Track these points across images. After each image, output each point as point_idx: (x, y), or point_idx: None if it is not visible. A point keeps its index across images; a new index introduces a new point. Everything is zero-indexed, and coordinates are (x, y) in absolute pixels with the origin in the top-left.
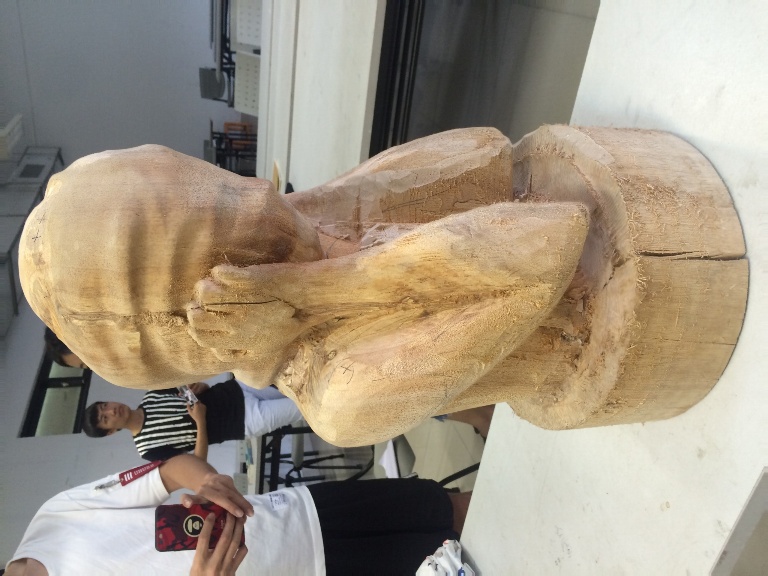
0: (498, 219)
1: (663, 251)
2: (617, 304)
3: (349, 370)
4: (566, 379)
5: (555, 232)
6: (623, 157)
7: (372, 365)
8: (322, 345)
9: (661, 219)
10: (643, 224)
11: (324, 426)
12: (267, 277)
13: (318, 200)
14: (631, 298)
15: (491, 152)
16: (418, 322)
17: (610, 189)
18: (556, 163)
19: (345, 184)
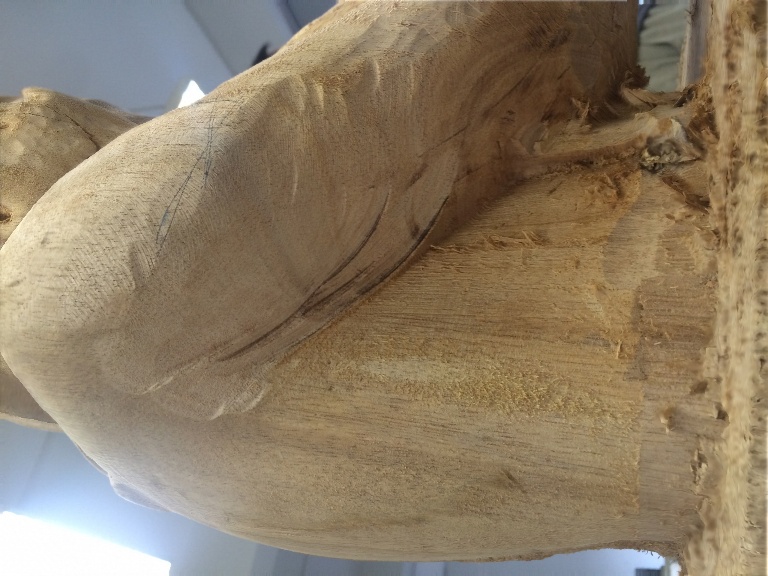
0: None
1: None
2: None
3: None
4: (716, 309)
5: None
6: None
7: None
8: None
9: None
10: None
11: None
12: (78, 100)
13: None
14: None
15: None
16: None
17: None
18: None
19: None
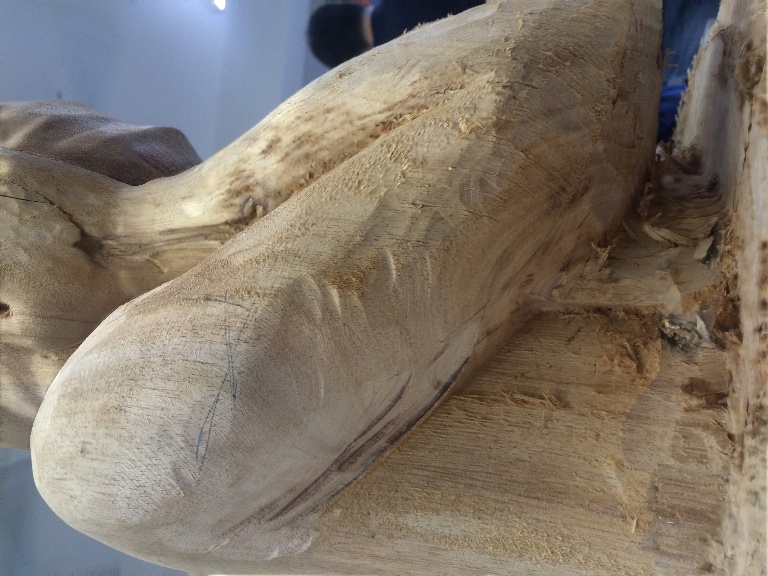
0: None
1: None
2: (763, 156)
3: None
4: (725, 501)
5: None
6: None
7: None
8: None
9: None
10: None
11: None
12: (43, 165)
13: None
14: None
15: None
16: None
17: None
18: None
19: None
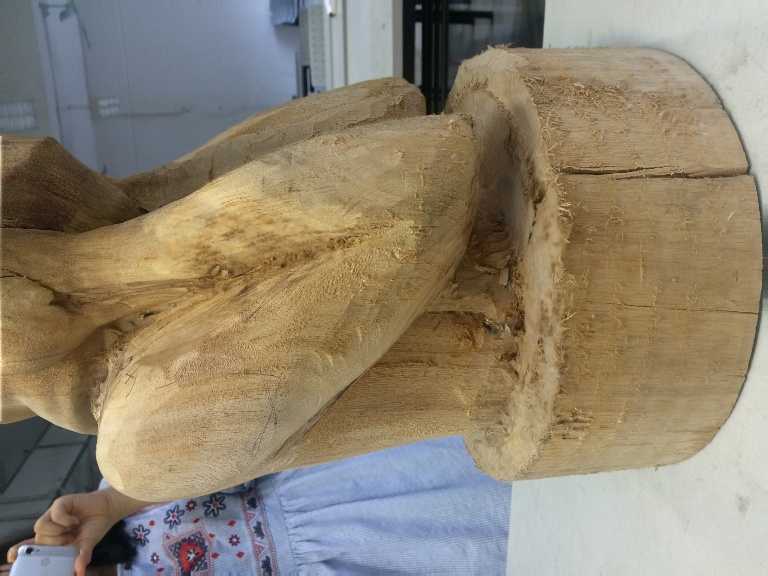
0: (333, 138)
1: (602, 167)
2: (544, 258)
3: (132, 377)
4: (510, 396)
5: (416, 146)
6: (543, 60)
7: (159, 366)
8: (123, 353)
9: (597, 125)
10: (566, 131)
11: (103, 466)
12: None
13: (160, 180)
14: (556, 240)
15: (387, 100)
16: (234, 302)
17: (520, 98)
18: (472, 101)
19: (195, 157)
